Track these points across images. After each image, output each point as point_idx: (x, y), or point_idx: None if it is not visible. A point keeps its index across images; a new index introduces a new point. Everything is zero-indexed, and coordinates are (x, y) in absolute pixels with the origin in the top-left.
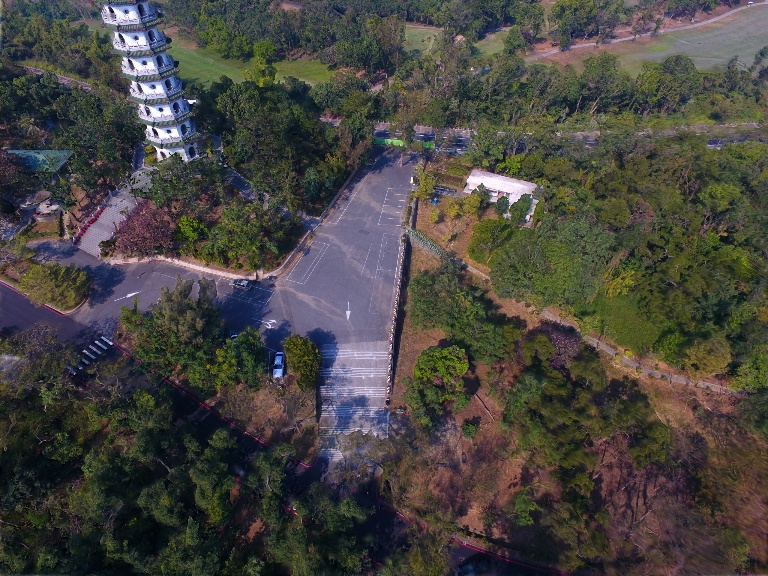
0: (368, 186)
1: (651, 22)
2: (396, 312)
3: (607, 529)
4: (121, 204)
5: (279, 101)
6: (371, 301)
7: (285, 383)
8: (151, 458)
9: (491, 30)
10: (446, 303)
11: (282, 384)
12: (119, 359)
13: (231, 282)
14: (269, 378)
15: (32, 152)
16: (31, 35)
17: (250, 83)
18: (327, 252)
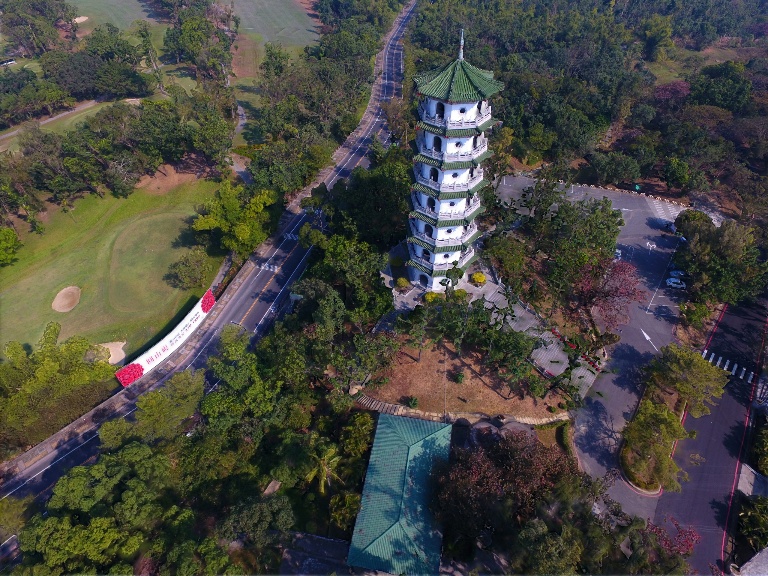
0: None
1: (230, 21)
2: None
3: (757, 141)
4: None
5: None
6: (609, 199)
7: None
8: None
9: None
10: None
11: None
12: None
13: None
14: None
15: (387, 477)
16: None
17: (324, 186)
18: None
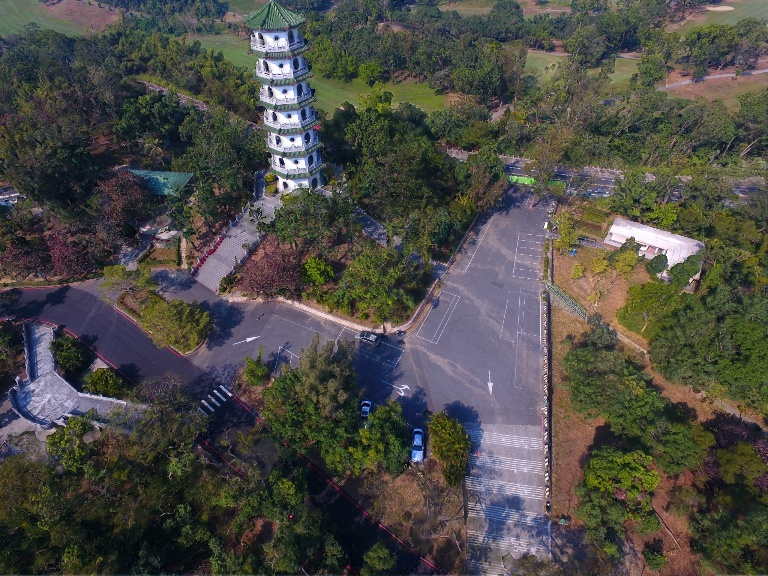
0: (496, 229)
1: None
2: (547, 389)
3: None
4: (241, 236)
5: (404, 132)
6: (515, 372)
7: (426, 469)
8: (296, 568)
9: (607, 56)
10: (617, 390)
11: (422, 470)
12: (253, 429)
13: (357, 335)
14: (407, 460)
15: (153, 173)
16: (148, 51)
17: None
18: (458, 306)
